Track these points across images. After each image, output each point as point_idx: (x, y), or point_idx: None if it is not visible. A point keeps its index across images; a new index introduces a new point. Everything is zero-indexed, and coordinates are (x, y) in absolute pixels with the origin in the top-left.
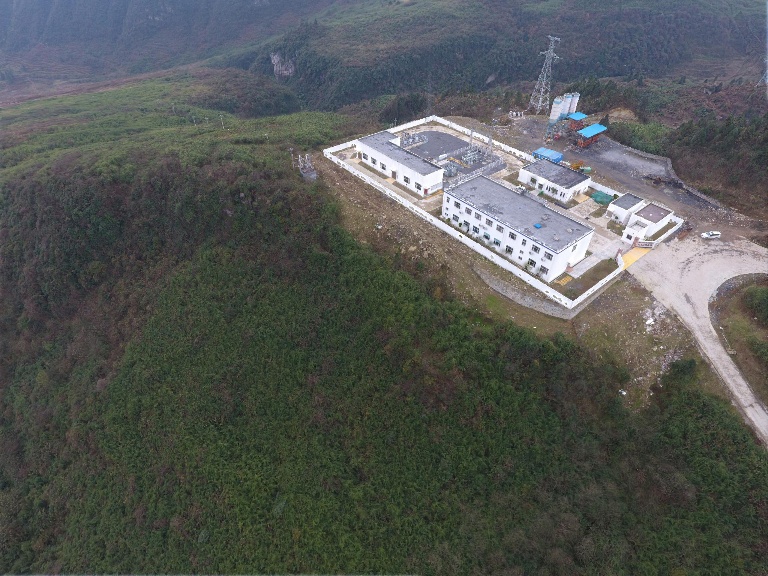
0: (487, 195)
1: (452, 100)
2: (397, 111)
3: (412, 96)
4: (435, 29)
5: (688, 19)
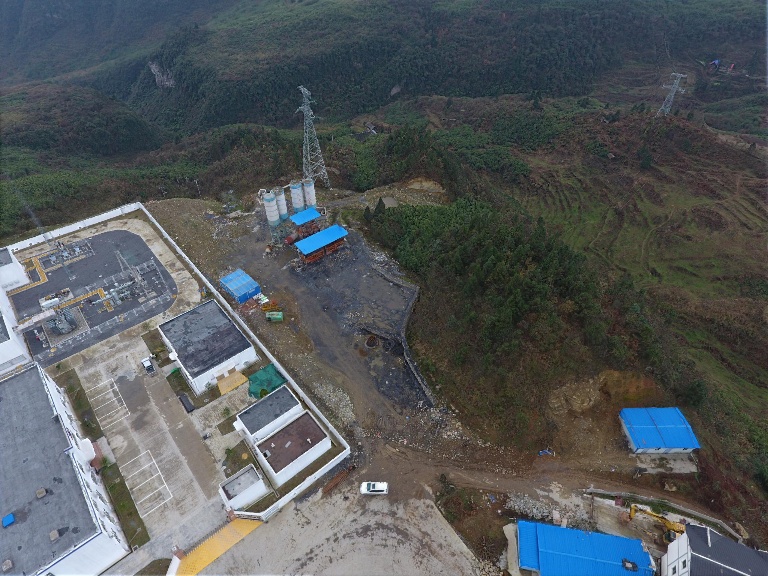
0: (0, 422)
1: (233, 156)
2: (219, 152)
3: (240, 132)
4: (328, 34)
5: (617, 19)
